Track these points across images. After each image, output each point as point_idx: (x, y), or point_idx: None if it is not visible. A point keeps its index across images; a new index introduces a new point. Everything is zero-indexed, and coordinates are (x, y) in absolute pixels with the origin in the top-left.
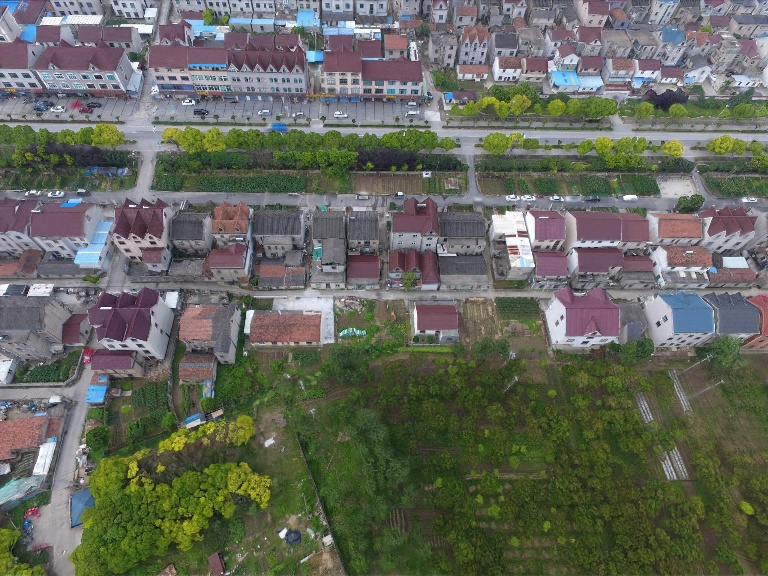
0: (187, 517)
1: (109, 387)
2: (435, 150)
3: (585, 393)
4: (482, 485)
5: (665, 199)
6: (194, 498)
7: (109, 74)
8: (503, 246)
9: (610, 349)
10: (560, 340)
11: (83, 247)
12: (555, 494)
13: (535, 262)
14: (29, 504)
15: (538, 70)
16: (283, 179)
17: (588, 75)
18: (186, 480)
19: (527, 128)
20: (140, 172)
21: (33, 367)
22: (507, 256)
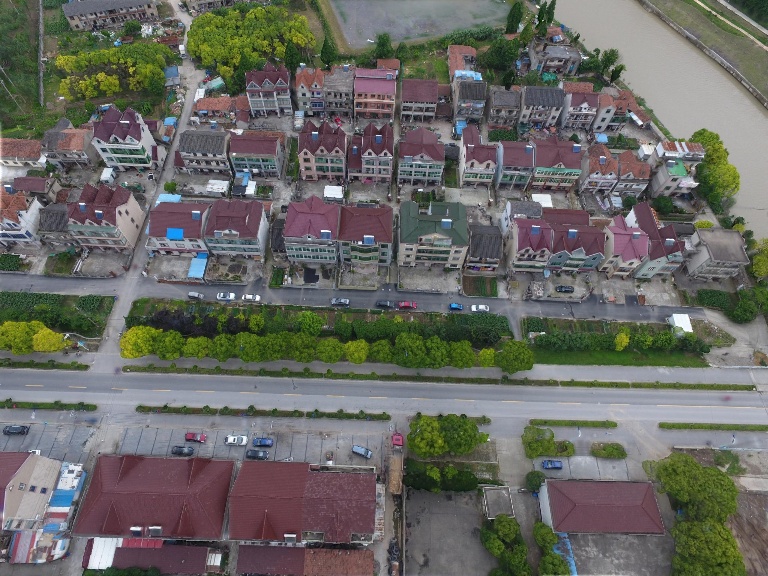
0: None
1: None
2: None
3: None
4: None
5: None
6: None
7: None
8: None
9: None
10: None
11: None
12: None
13: None
14: None
15: None
16: None
17: None
18: None
19: None
20: None
21: None
22: None
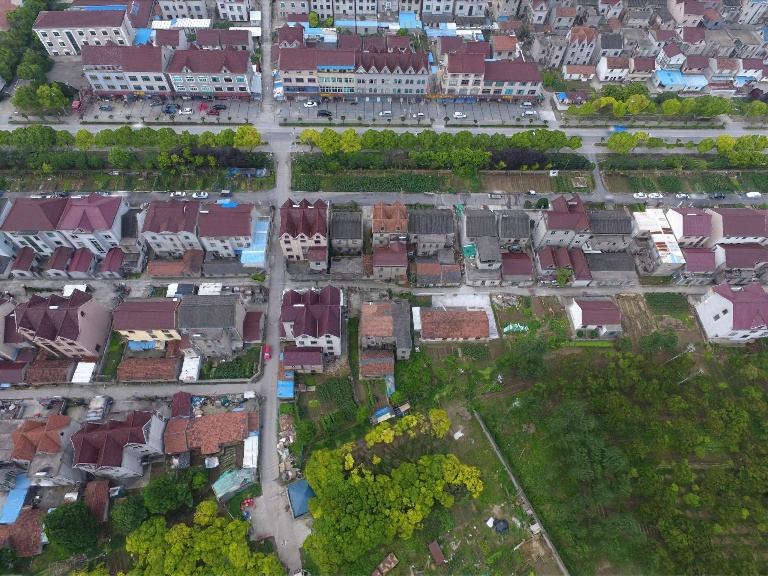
0: (410, 507)
1: (295, 383)
2: None
3: (756, 385)
4: (677, 474)
5: None
6: (416, 488)
7: (239, 77)
8: (645, 243)
9: (764, 342)
10: (722, 334)
11: (244, 247)
12: (748, 483)
13: (684, 258)
14: (243, 496)
15: (645, 70)
16: (417, 179)
17: (692, 74)
18: (407, 471)
19: (642, 127)
20: (277, 173)
21: (216, 364)
22: (652, 252)
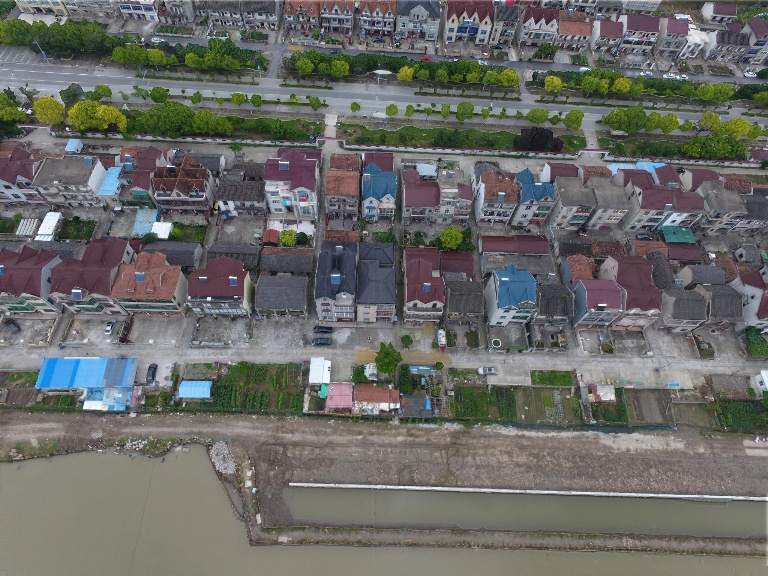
0: None
1: None
2: (763, 112)
3: None
4: None
5: None
6: None
7: None
8: None
9: None
10: None
11: None
12: None
13: None
14: None
15: None
16: None
17: None
18: None
19: None
20: None
21: None
22: None
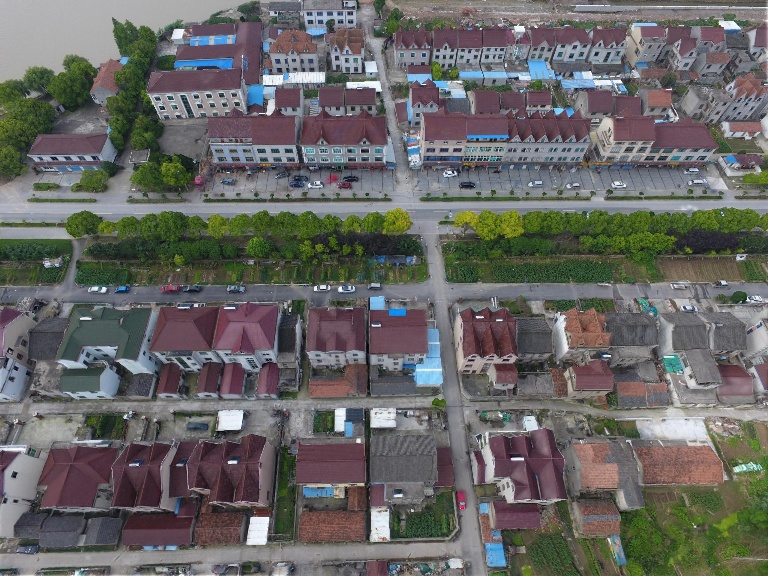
0: None
1: (502, 543)
2: None
3: None
4: None
5: None
6: None
7: (378, 148)
8: None
9: None
10: None
11: (415, 361)
12: None
13: None
14: None
15: None
16: (586, 266)
17: None
18: None
19: None
20: (428, 260)
21: (404, 515)
22: None
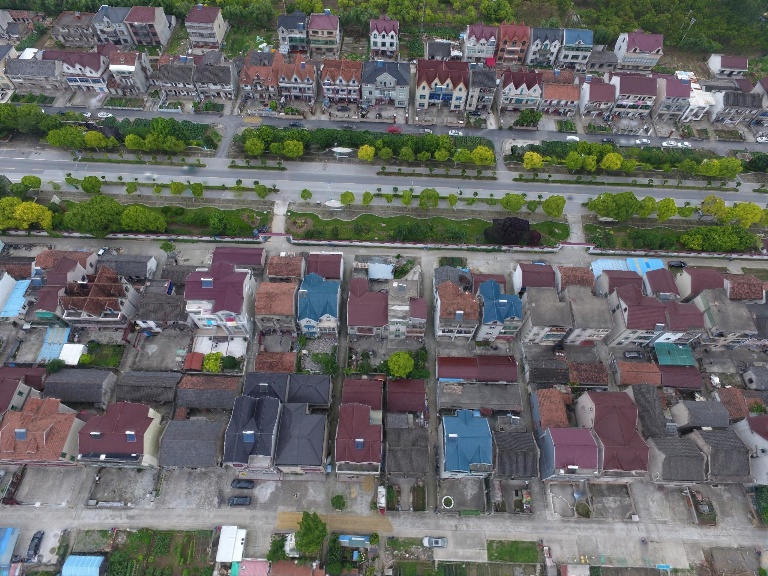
0: None
1: None
2: None
3: None
4: None
5: (537, 140)
6: None
7: None
8: None
9: None
10: None
11: None
12: None
13: None
14: None
15: None
16: None
17: None
18: None
19: None
20: None
21: None
22: None
